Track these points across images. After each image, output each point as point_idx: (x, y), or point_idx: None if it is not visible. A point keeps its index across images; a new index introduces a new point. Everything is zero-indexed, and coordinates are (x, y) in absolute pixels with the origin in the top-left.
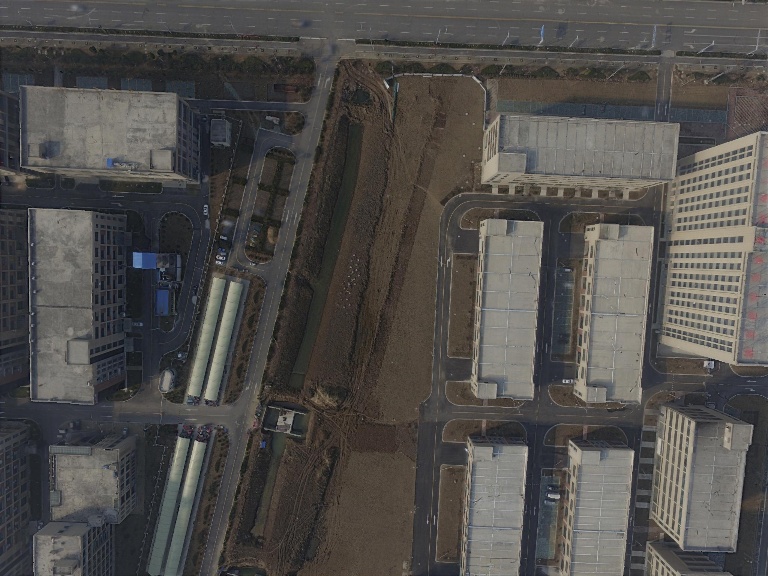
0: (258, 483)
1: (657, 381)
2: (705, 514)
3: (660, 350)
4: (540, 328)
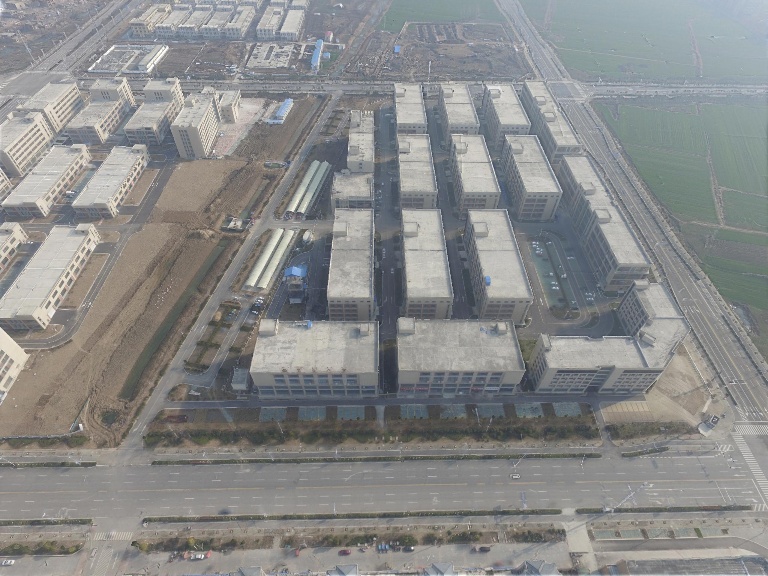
0: None
1: None
2: None
3: None
4: None
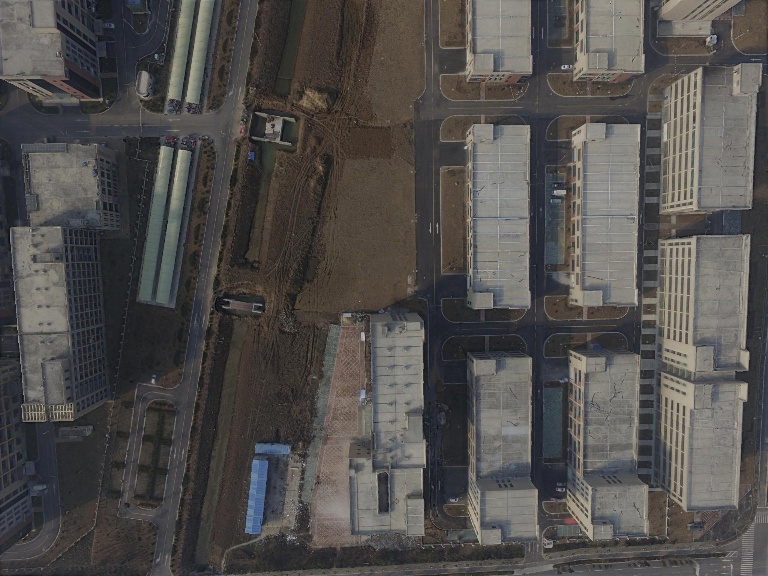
0: (249, 200)
1: (659, 63)
2: (718, 170)
3: (660, 33)
4: (535, 12)
